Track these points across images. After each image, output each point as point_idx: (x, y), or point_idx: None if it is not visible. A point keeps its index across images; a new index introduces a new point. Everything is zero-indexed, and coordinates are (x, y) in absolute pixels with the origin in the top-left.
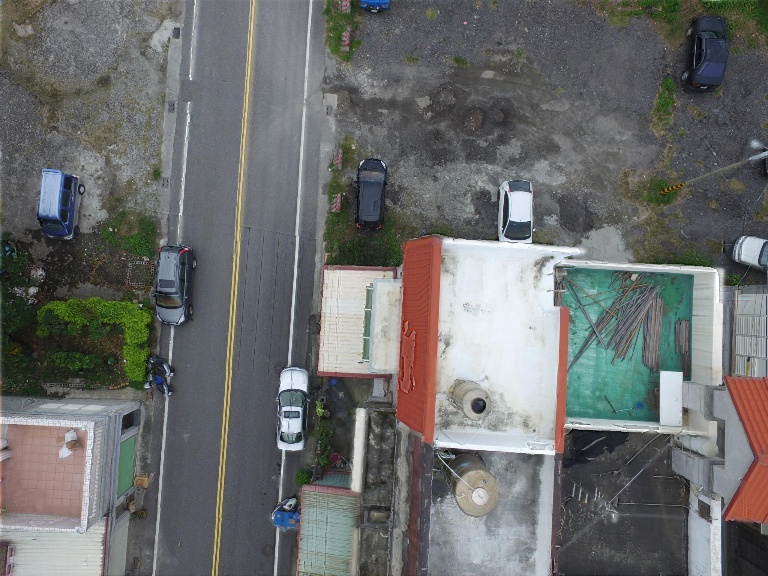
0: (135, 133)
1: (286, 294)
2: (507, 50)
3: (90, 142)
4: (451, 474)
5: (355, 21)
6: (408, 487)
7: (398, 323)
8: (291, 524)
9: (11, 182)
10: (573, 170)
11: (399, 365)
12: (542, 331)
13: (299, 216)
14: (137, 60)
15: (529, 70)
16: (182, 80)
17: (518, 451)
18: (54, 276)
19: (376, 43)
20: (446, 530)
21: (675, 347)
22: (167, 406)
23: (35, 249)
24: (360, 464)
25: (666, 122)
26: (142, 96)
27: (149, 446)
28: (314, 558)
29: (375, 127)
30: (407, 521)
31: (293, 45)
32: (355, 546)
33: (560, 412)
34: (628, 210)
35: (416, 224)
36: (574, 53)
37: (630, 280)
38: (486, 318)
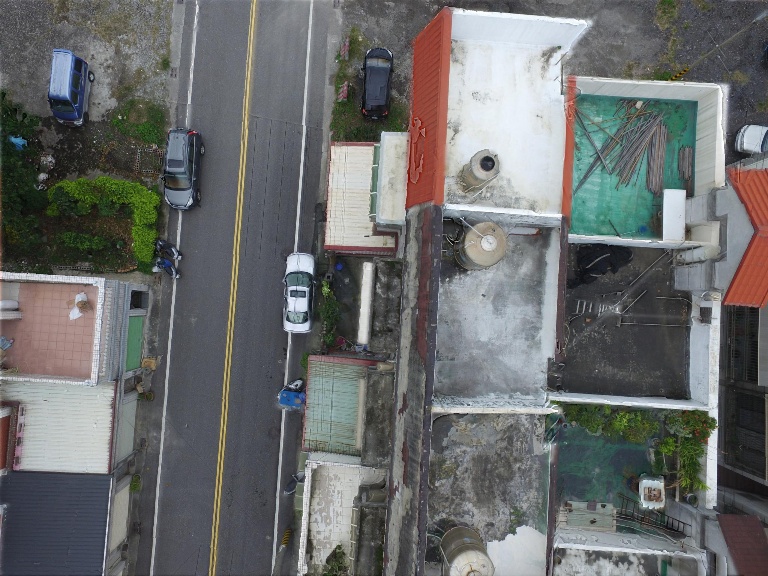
0: (144, 23)
1: (293, 182)
2: None
3: (100, 31)
4: (460, 239)
5: None
6: (417, 262)
7: (405, 176)
8: (297, 403)
9: (21, 70)
10: (578, 62)
11: None
12: (549, 119)
13: (306, 106)
14: None
15: None
16: None
17: (525, 213)
18: (64, 163)
19: None
20: (454, 309)
21: (678, 173)
22: (175, 290)
23: (45, 136)
24: (367, 316)
25: (670, 15)
26: None
27: (157, 329)
28: (320, 426)
29: (382, 19)
30: (416, 294)
31: None
32: (361, 396)
33: (566, 210)
34: None
35: None
36: None
37: (635, 108)
38: (494, 106)
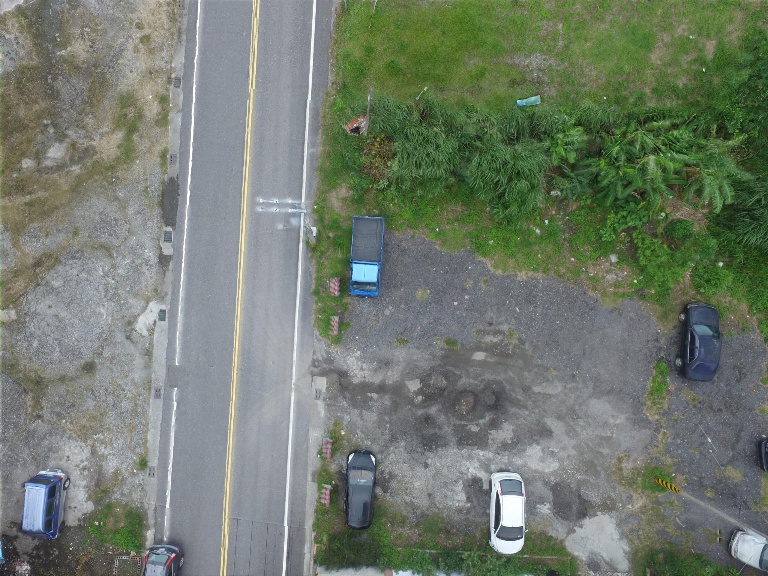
0: (121, 421)
1: None
2: (498, 330)
3: (75, 431)
4: None
5: (344, 302)
6: None
7: None
8: None
9: None
10: (566, 456)
11: None
12: None
13: (288, 505)
14: (122, 344)
15: (521, 351)
16: (168, 365)
17: None
18: (39, 571)
19: (365, 324)
20: None
21: None
22: None
23: (20, 543)
24: None
25: (660, 407)
26: (128, 382)
27: None
28: None
29: (365, 412)
30: None
31: (281, 327)
32: None
33: None
34: (622, 497)
35: (407, 512)
36: (566, 334)
37: None
38: None
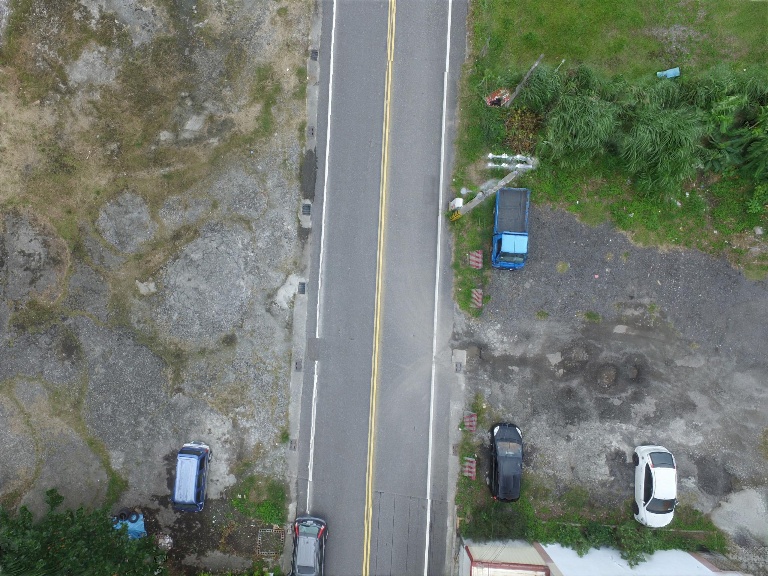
0: (262, 394)
1: (418, 560)
2: (639, 304)
3: (216, 404)
4: None
5: (484, 275)
6: None
7: None
8: None
9: (137, 447)
10: (710, 430)
11: None
12: None
13: (430, 479)
14: (262, 317)
15: (662, 324)
16: (308, 338)
17: None
18: (182, 544)
19: (505, 297)
20: None
21: None
22: None
23: (162, 515)
24: None
25: None
26: (268, 355)
27: None
28: None
29: (506, 385)
30: None
31: (421, 300)
32: None
33: None
34: (767, 471)
35: (550, 486)
36: (709, 307)
37: None
38: None
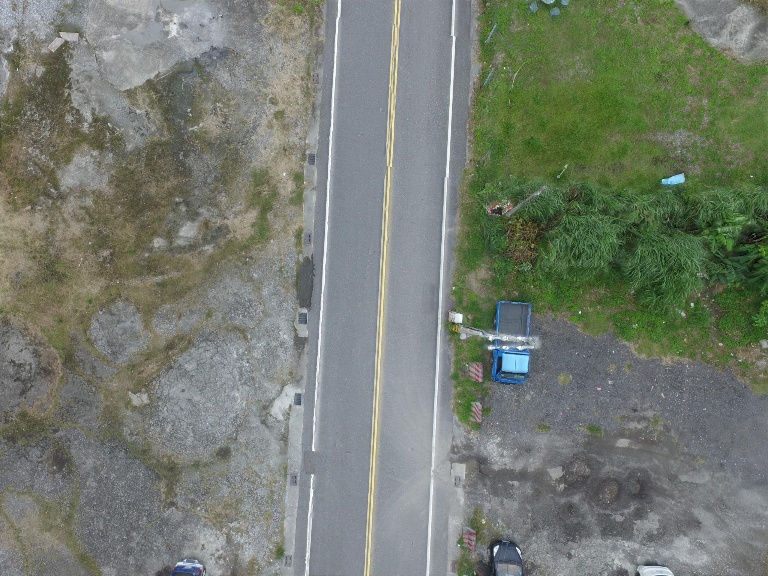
0: (257, 509)
1: None
2: (643, 417)
3: (210, 519)
4: None
5: (484, 387)
6: None
7: None
8: None
9: (129, 564)
10: (714, 548)
11: None
12: None
13: None
14: (257, 429)
15: (666, 438)
16: (304, 450)
17: None
18: None
19: (506, 410)
20: None
21: None
22: None
23: None
24: None
25: None
26: (263, 468)
27: None
28: None
29: (506, 500)
30: None
31: (419, 412)
32: None
33: None
34: None
35: None
36: (713, 421)
37: None
38: None
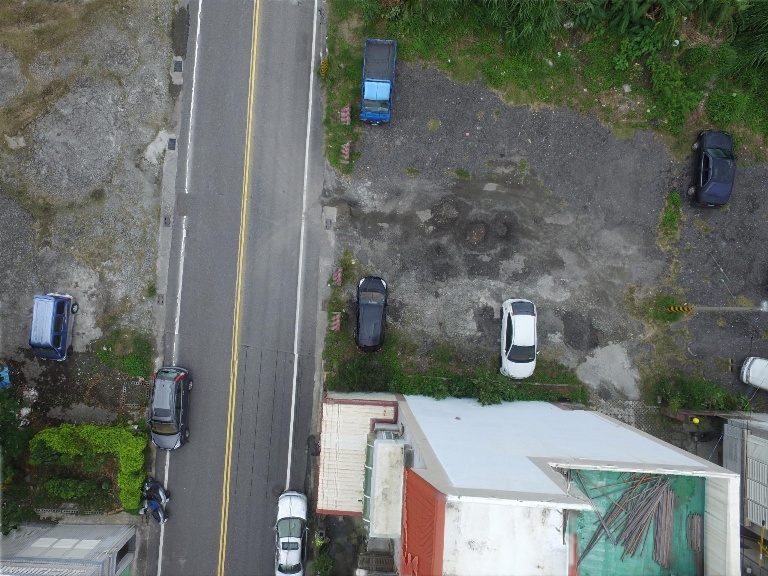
0: (130, 248)
1: (284, 414)
2: (510, 162)
3: (84, 258)
4: None
5: (355, 132)
6: None
7: (400, 485)
8: None
9: (3, 300)
10: (577, 286)
11: (401, 530)
12: (551, 570)
13: (298, 333)
14: (132, 173)
15: (532, 182)
16: (178, 193)
17: None
18: (47, 396)
19: (376, 155)
20: None
21: (686, 542)
22: (163, 531)
23: (27, 368)
24: None
25: (672, 237)
26: (137, 210)
27: (144, 572)
28: None
29: (375, 241)
30: None
31: (291, 157)
32: None
33: None
34: (634, 327)
35: (417, 341)
36: (578, 165)
37: None
38: (492, 557)
